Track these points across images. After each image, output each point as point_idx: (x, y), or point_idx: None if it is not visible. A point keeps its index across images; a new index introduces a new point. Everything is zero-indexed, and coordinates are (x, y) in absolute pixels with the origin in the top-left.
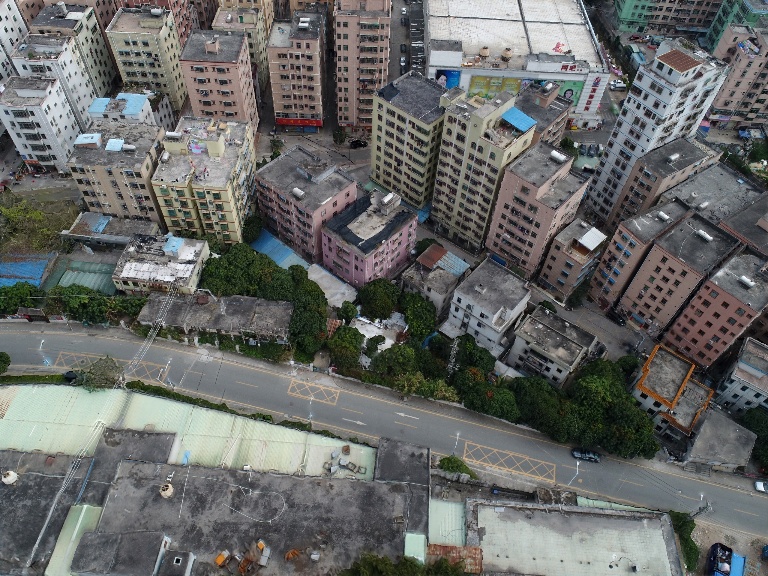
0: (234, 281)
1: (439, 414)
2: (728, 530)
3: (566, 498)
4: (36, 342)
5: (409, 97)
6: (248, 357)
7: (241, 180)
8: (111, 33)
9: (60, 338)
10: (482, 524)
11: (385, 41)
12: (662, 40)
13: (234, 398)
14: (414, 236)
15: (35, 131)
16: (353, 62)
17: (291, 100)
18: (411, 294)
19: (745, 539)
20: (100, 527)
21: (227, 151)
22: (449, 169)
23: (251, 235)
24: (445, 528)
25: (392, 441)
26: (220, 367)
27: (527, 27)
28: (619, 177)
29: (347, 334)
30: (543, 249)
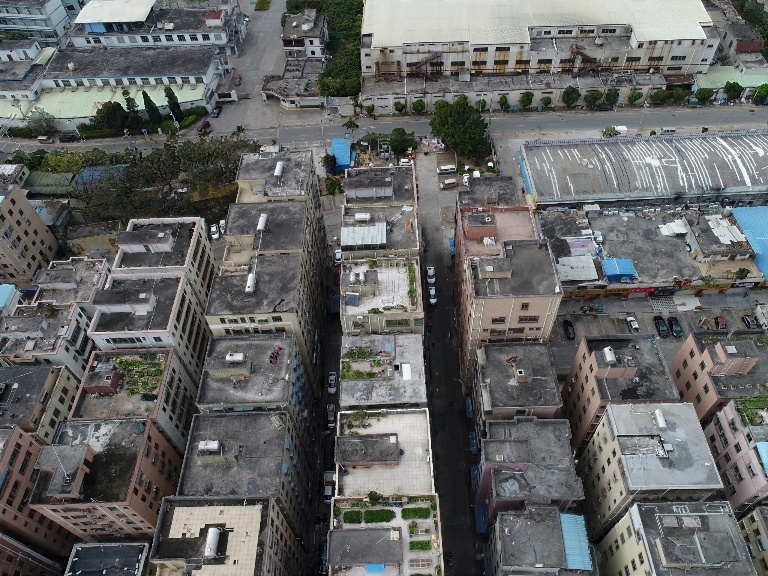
0: None
1: None
2: None
3: None
4: None
5: None
6: None
7: None
8: None
9: None
10: None
11: None
12: None
13: None
14: None
15: None
16: None
17: None
18: None
19: None
20: None
21: None
22: None
23: None
24: None
25: None
26: None
27: None
28: None
29: None
30: None
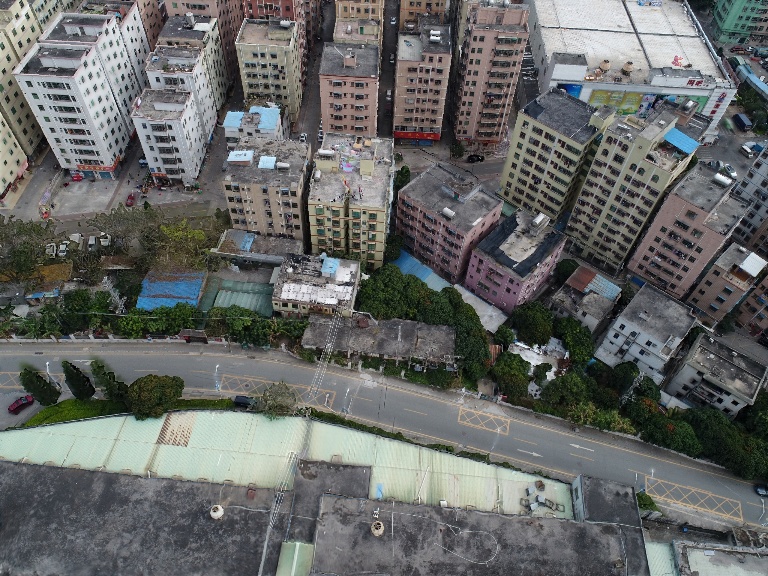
0: (393, 304)
1: (613, 446)
2: None
3: (764, 539)
4: (197, 364)
5: (555, 115)
6: (413, 383)
7: (390, 199)
8: (241, 45)
9: (220, 360)
10: (694, 568)
11: (519, 56)
12: (767, 52)
13: (405, 426)
14: (558, 257)
15: (170, 145)
16: (482, 76)
17: (413, 113)
18: (566, 319)
19: None
20: (315, 566)
21: (377, 169)
22: (597, 189)
23: (394, 254)
24: (655, 571)
25: (594, 479)
26: (386, 393)
27: (641, 39)
28: (764, 198)
29: (513, 361)
30: (698, 274)
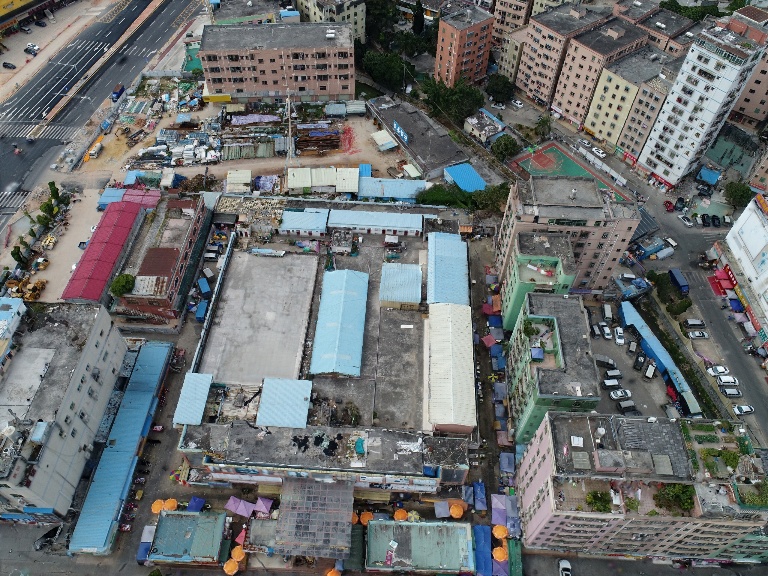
0: None
1: None
2: (606, 6)
3: None
4: None
5: None
6: None
7: None
8: None
9: None
10: None
11: None
12: None
13: None
14: None
15: None
16: None
17: None
18: None
19: (598, 5)
20: None
21: None
22: None
23: None
24: None
25: None
26: None
27: None
28: None
29: None
30: None
